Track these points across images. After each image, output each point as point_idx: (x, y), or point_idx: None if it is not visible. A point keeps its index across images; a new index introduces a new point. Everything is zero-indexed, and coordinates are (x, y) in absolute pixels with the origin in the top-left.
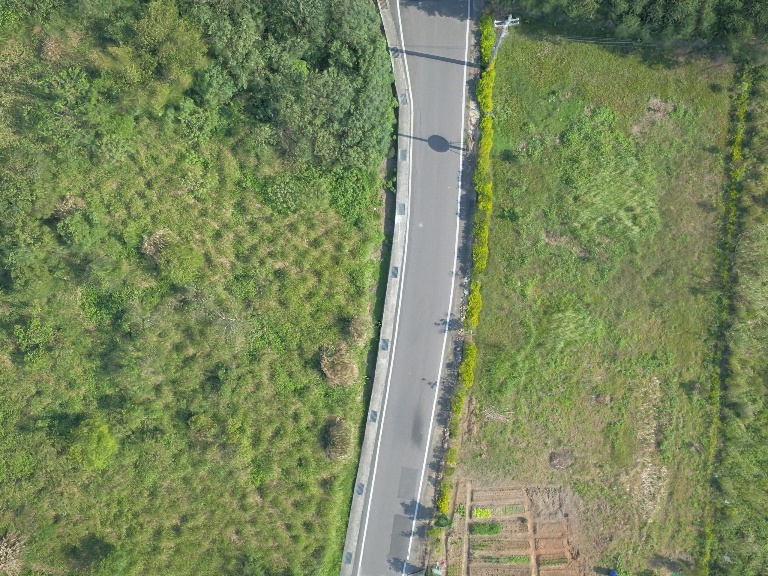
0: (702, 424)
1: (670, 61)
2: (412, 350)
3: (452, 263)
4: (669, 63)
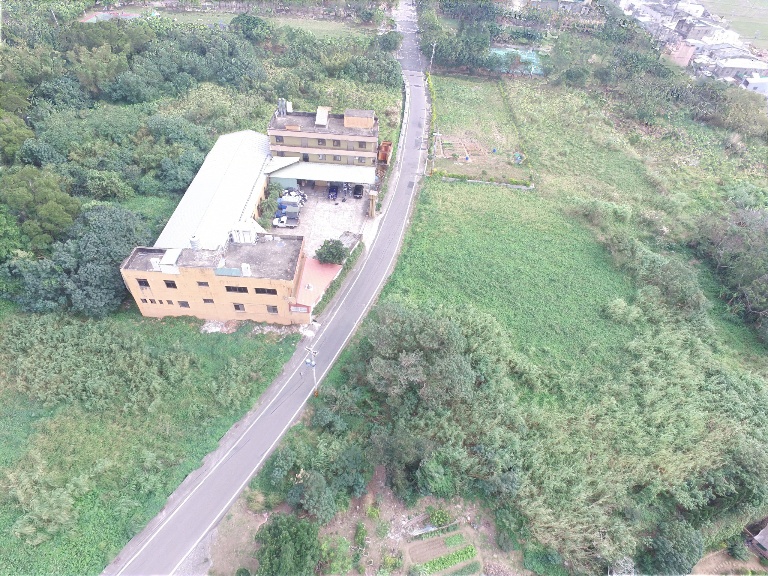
0: None
1: (479, 82)
2: (415, 113)
3: None
4: (479, 82)
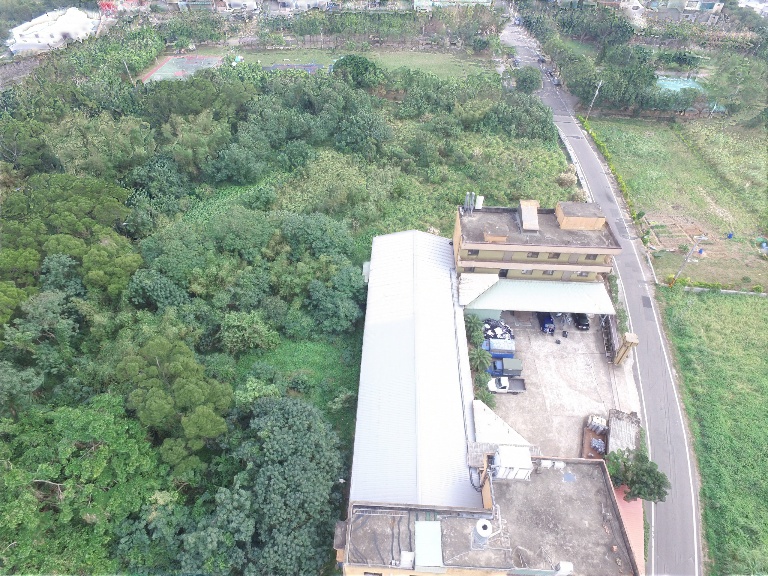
0: (729, 198)
1: (646, 126)
2: None
3: (597, 160)
4: (646, 126)
